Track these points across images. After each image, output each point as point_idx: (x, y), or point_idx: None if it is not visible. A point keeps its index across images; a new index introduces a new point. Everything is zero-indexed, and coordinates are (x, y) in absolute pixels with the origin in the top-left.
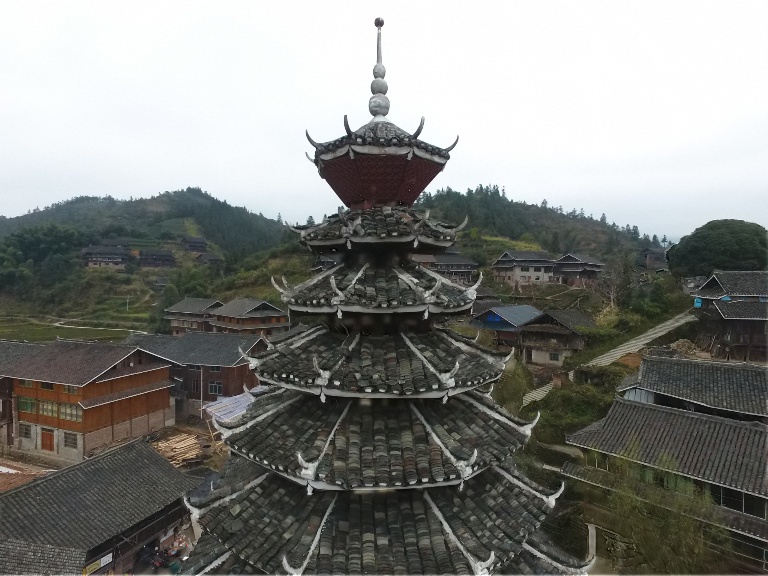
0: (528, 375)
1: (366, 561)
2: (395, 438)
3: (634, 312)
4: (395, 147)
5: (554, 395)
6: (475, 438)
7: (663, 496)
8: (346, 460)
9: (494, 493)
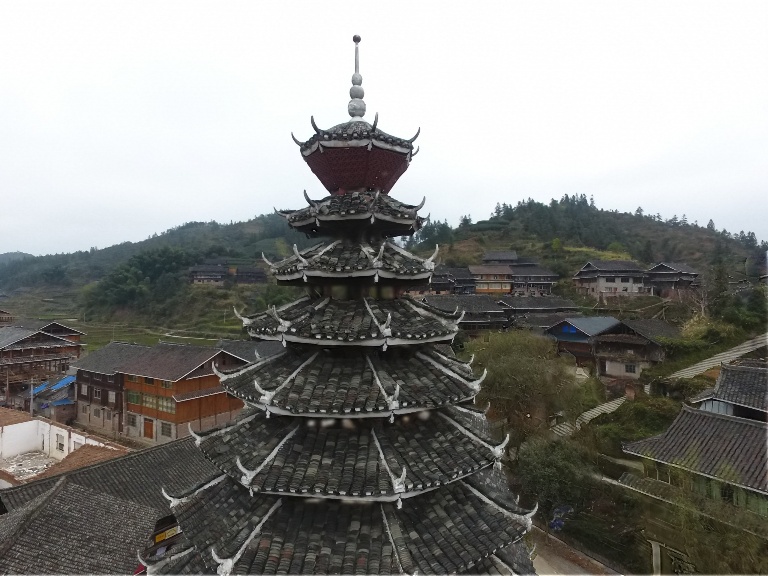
0: (600, 387)
1: (308, 473)
2: (346, 380)
3: (726, 322)
4: (356, 140)
5: (626, 408)
6: (420, 387)
7: (732, 513)
8: (300, 394)
9: (442, 439)
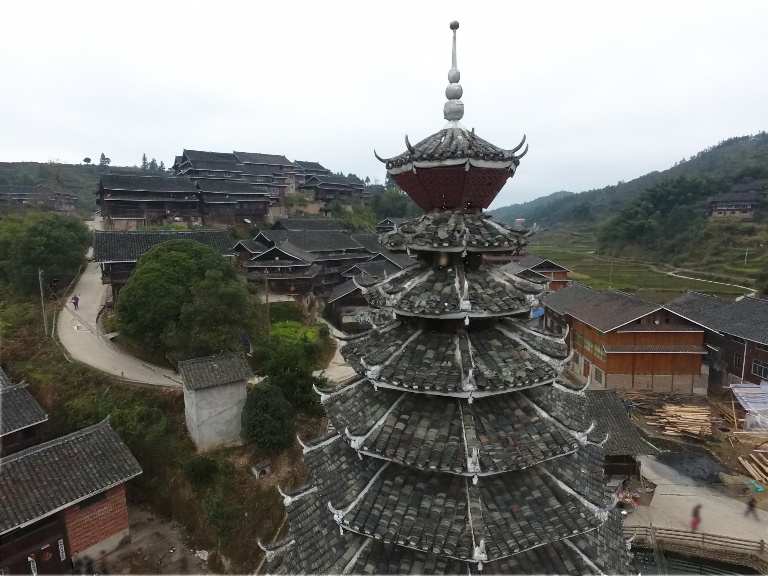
0: None
1: (328, 467)
2: (371, 405)
3: None
4: (405, 165)
5: None
6: (415, 437)
7: None
8: (344, 403)
9: (438, 502)
